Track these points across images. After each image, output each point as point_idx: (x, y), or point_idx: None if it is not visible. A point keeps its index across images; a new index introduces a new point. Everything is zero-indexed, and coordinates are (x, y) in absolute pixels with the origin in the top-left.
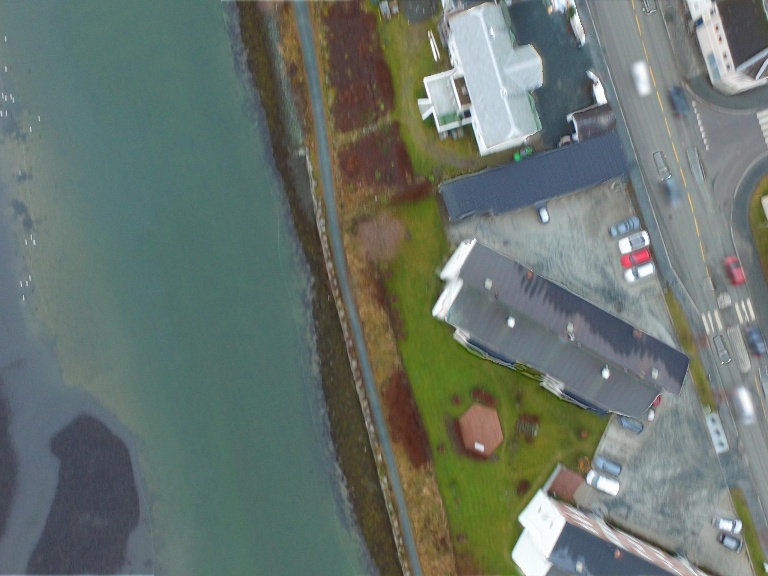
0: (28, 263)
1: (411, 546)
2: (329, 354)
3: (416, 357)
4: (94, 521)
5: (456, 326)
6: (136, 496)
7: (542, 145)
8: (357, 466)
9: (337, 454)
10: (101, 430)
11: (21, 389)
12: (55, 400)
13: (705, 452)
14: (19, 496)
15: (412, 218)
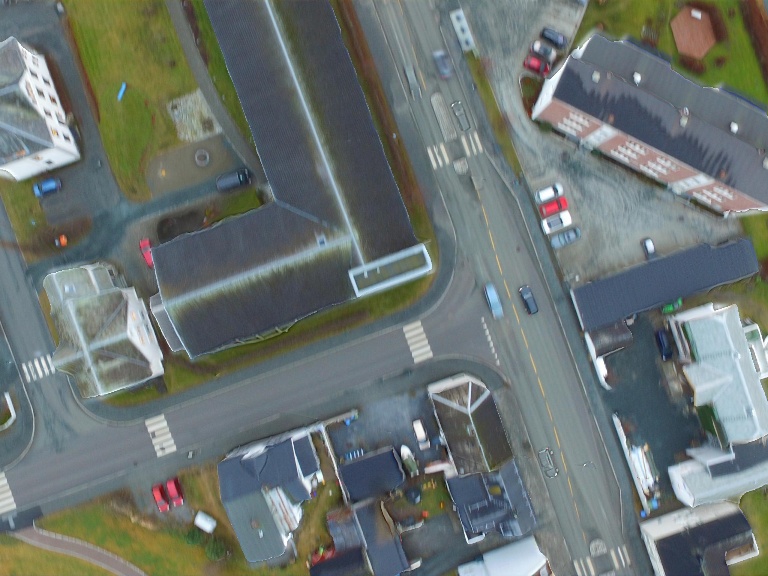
0: None
1: None
2: None
3: (759, 105)
4: None
5: None
6: None
7: (650, 316)
8: None
9: None
10: None
11: None
12: None
13: (474, 10)
14: None
15: (767, 242)
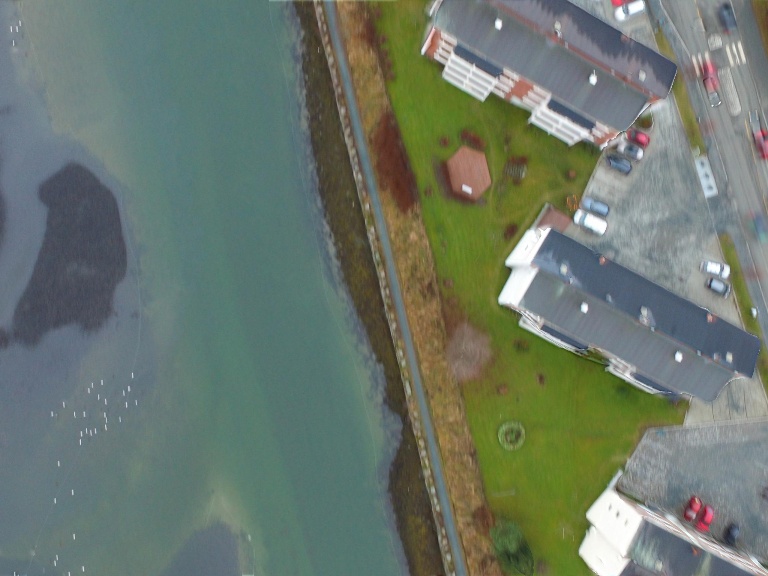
0: (18, 8)
1: (398, 298)
2: (318, 108)
3: (405, 98)
4: (81, 270)
5: (443, 33)
6: (123, 246)
7: None
8: (345, 221)
9: (325, 210)
10: (89, 179)
11: (10, 135)
12: (44, 147)
13: (694, 196)
14: (7, 243)
15: None
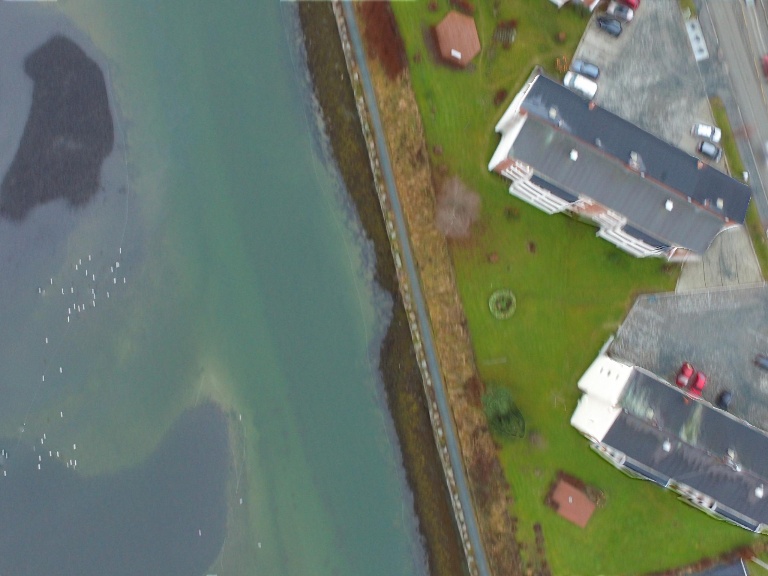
0: None
1: (387, 170)
2: None
3: None
4: (68, 144)
5: None
6: (110, 120)
7: None
8: (334, 95)
9: (314, 84)
10: (75, 51)
11: None
12: (29, 19)
13: (684, 59)
14: None
15: None
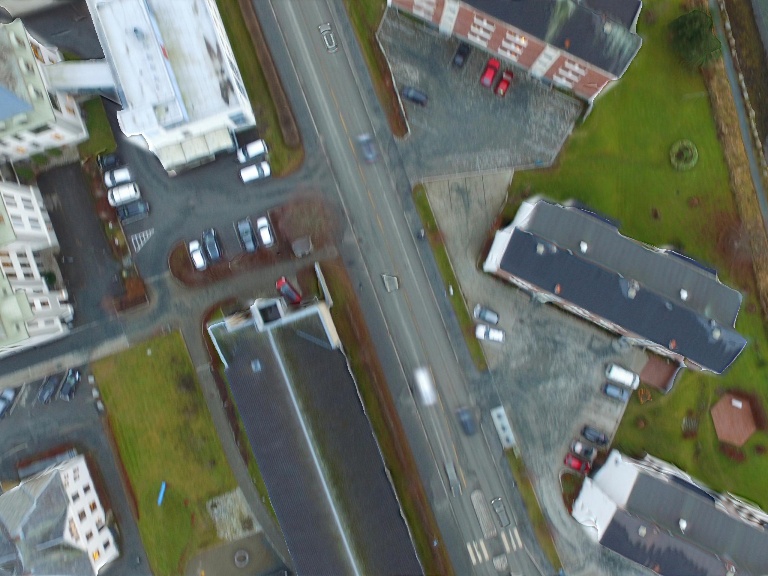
0: None
1: None
2: None
3: None
4: None
5: None
6: None
7: None
8: None
9: None
10: None
11: None
12: None
13: (515, 407)
14: None
15: None
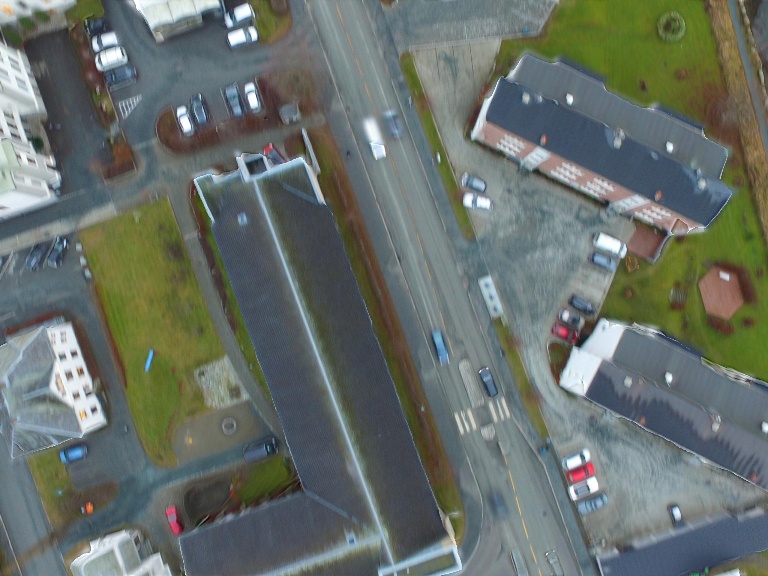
0: None
1: None
2: None
3: None
4: None
5: None
6: None
7: None
8: None
9: None
10: None
11: None
12: None
13: (503, 276)
14: None
15: None
